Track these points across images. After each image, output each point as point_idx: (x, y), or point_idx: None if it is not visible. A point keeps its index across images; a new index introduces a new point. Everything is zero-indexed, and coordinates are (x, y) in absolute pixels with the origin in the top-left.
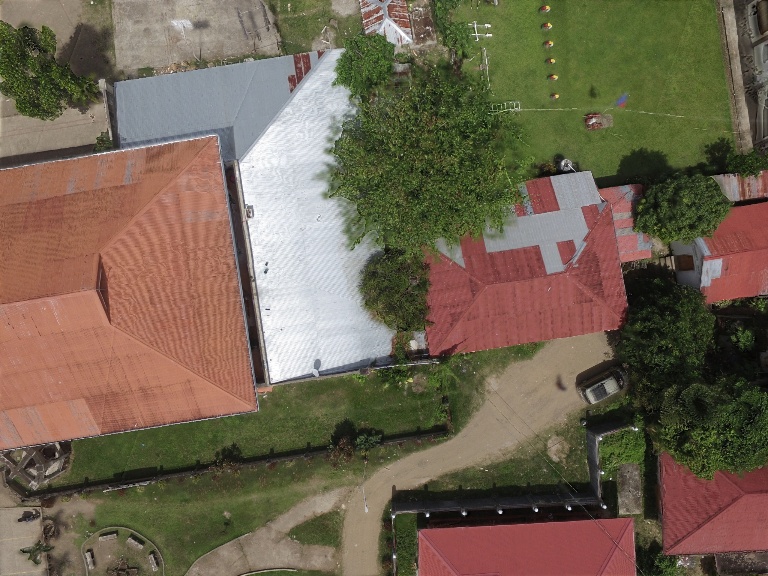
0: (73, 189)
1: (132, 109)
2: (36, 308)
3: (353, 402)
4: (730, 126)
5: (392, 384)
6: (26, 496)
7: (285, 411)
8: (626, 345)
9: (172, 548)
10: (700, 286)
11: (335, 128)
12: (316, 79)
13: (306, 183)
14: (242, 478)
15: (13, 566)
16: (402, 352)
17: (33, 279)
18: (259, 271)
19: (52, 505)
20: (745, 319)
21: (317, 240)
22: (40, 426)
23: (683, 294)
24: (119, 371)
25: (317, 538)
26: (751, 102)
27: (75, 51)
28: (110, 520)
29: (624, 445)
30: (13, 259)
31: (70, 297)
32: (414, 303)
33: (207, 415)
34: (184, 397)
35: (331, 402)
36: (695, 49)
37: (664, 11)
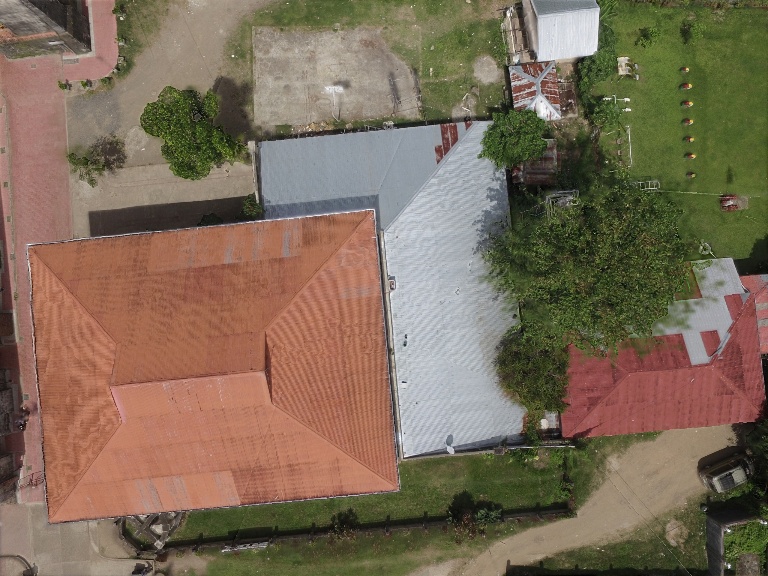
0: (231, 258)
1: (276, 171)
2: (202, 385)
3: (473, 474)
4: None
5: None
6: (141, 549)
7: (404, 478)
8: (766, 441)
9: None
10: None
11: (478, 201)
12: (462, 151)
13: (448, 256)
14: (356, 543)
15: None
16: (535, 432)
17: (199, 355)
18: (398, 343)
19: (166, 559)
20: None
21: (455, 314)
22: (182, 494)
23: None
24: (271, 447)
25: None
26: None
27: None
28: None
29: (746, 535)
30: (176, 331)
31: (238, 377)
32: (552, 385)
33: (348, 492)
34: (330, 474)
35: (451, 472)
36: None
37: None
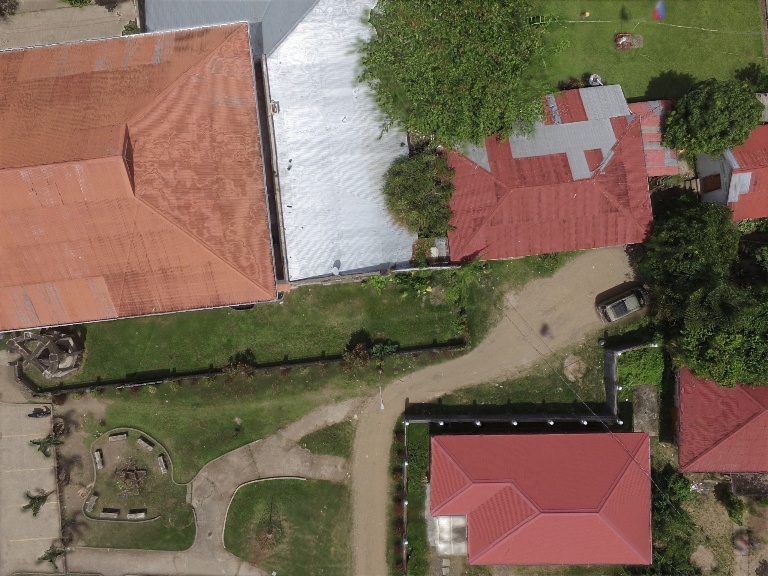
0: (101, 66)
1: (160, 2)
2: (61, 173)
3: (370, 312)
4: (761, 51)
5: (410, 295)
6: (37, 392)
7: (301, 318)
8: (650, 256)
9: (182, 452)
10: (727, 202)
11: (364, 30)
12: None
13: (333, 83)
14: (255, 384)
15: (21, 463)
16: (423, 256)
17: (59, 145)
18: (282, 167)
19: (63, 402)
20: None
21: (342, 140)
22: (58, 305)
23: (710, 207)
24: (140, 248)
25: (328, 448)
26: None
27: None
28: (120, 421)
29: (642, 365)
30: (39, 127)
31: (95, 163)
32: (437, 206)
33: (226, 302)
34: (204, 281)
35: (348, 311)
36: None
37: None
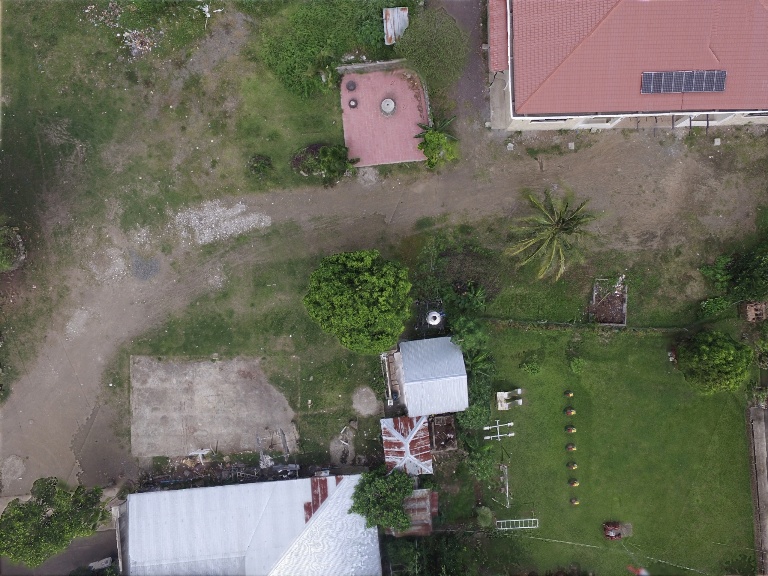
0: None
1: (144, 528)
2: None
3: None
4: (753, 544)
5: None
6: None
7: None
8: None
9: None
10: None
11: (348, 557)
12: (332, 507)
13: None
14: None
15: None
16: None
17: None
18: None
19: None
20: None
21: None
22: None
23: None
24: None
25: None
26: None
27: (91, 433)
28: None
29: None
30: None
31: None
32: None
33: None
34: None
35: None
36: (722, 460)
37: (692, 419)
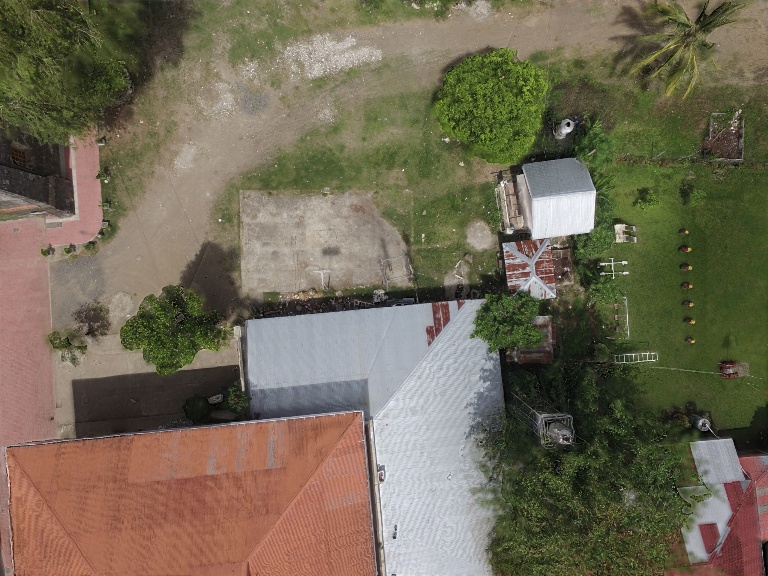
0: (214, 468)
1: (263, 352)
2: None
3: None
4: None
5: None
6: None
7: None
8: None
9: None
10: None
11: (471, 382)
12: (454, 331)
13: (439, 441)
14: None
15: None
16: None
17: None
18: (388, 536)
19: None
20: None
21: (447, 501)
22: None
23: None
24: None
25: None
26: None
27: (200, 269)
28: None
29: None
30: (156, 558)
31: None
32: None
33: None
34: None
35: None
36: None
37: None
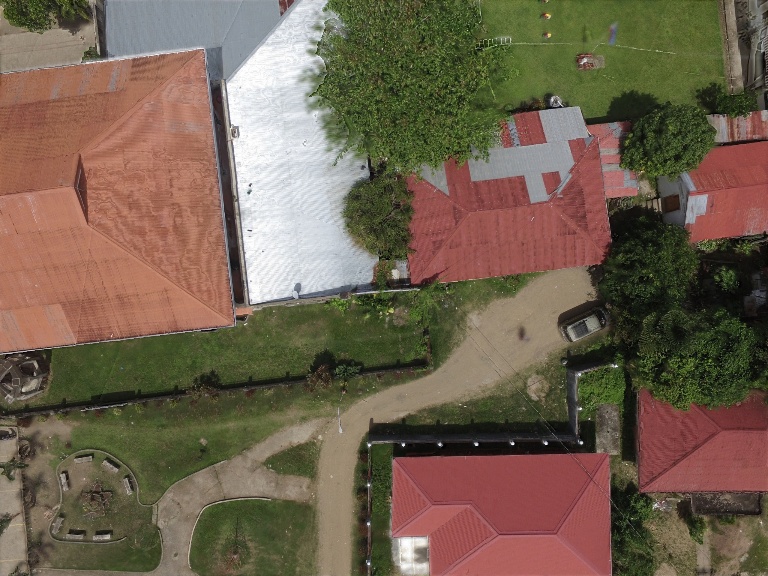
0: (57, 95)
1: (121, 27)
2: (14, 204)
3: (334, 333)
4: (722, 71)
5: (373, 316)
6: (3, 414)
7: (265, 340)
8: (608, 278)
9: (147, 473)
10: (685, 223)
11: None
12: (307, 4)
13: (293, 107)
14: (220, 405)
15: None
16: (383, 279)
17: (12, 176)
18: (242, 191)
19: (28, 425)
20: (730, 264)
21: (302, 164)
22: (16, 332)
23: (667, 229)
24: (96, 276)
25: (293, 468)
26: (744, 48)
27: None
28: (86, 443)
29: (604, 385)
30: None
31: (48, 194)
32: (397, 229)
33: (184, 328)
34: (161, 307)
35: (312, 332)
36: None
37: None
